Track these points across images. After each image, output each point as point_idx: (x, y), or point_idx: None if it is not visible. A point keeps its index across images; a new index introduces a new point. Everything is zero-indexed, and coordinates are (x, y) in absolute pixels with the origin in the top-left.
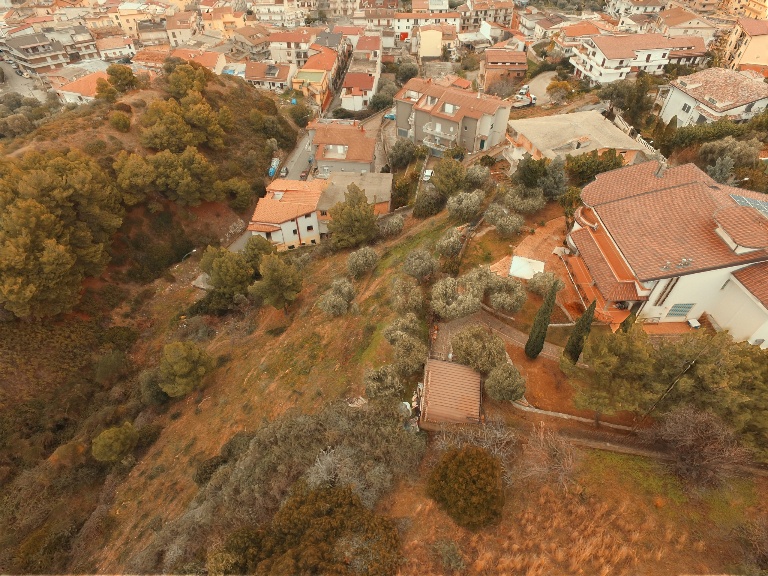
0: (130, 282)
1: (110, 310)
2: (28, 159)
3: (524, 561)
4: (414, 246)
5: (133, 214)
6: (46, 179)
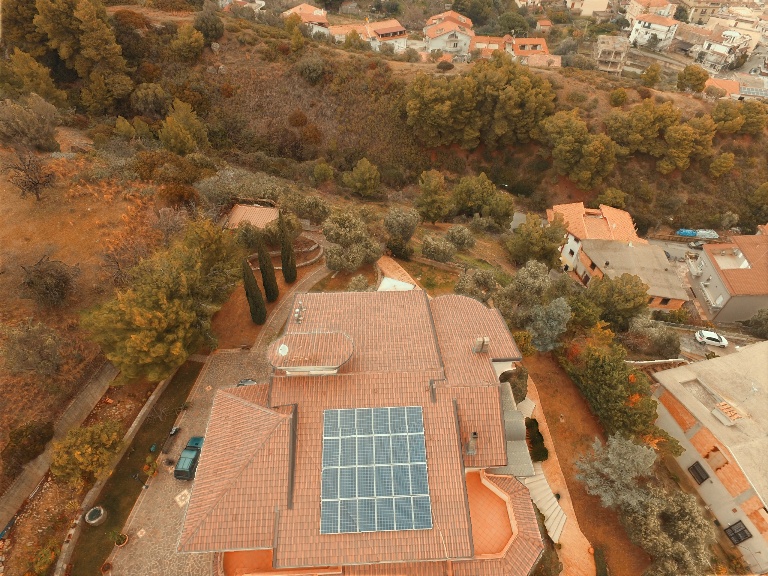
0: (475, 171)
1: (445, 169)
2: (520, 69)
3: (131, 215)
4: (481, 266)
5: (535, 147)
6: (495, 78)
